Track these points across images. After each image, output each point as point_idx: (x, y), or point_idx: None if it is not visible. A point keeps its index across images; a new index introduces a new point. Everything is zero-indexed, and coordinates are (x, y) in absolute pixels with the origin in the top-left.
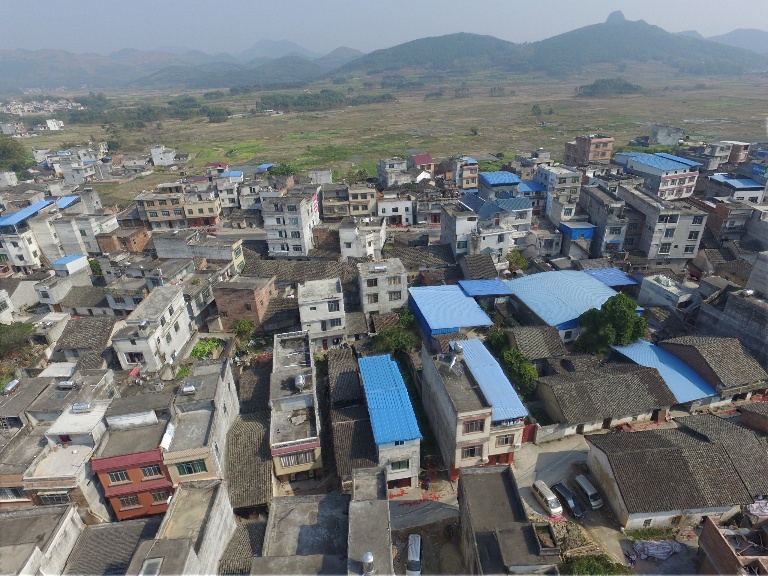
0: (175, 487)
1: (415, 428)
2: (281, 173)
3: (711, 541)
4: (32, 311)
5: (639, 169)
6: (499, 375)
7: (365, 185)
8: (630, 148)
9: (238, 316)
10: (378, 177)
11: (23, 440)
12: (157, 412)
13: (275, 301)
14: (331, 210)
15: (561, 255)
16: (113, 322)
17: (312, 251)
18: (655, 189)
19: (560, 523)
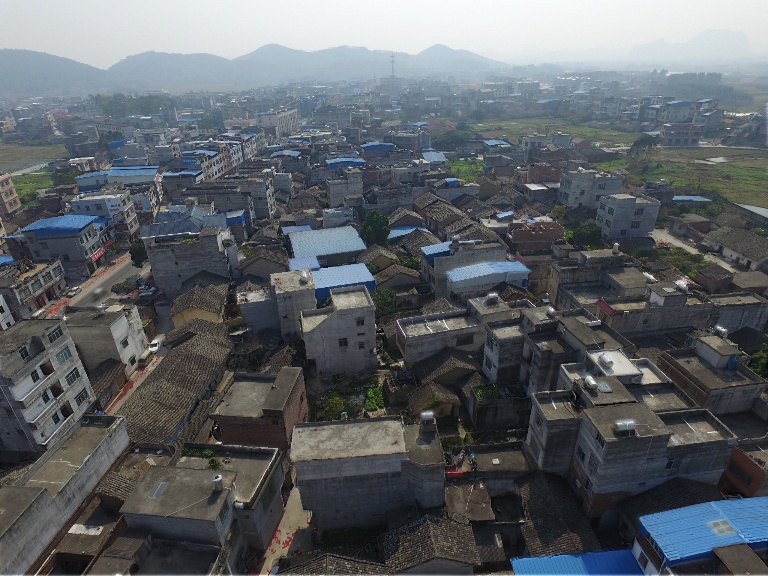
0: None
1: (515, 262)
2: None
3: (519, 236)
4: None
5: (126, 182)
6: None
7: None
8: None
9: None
10: None
11: None
12: None
13: None
14: None
15: (238, 243)
16: (337, 557)
17: None
18: None
19: None
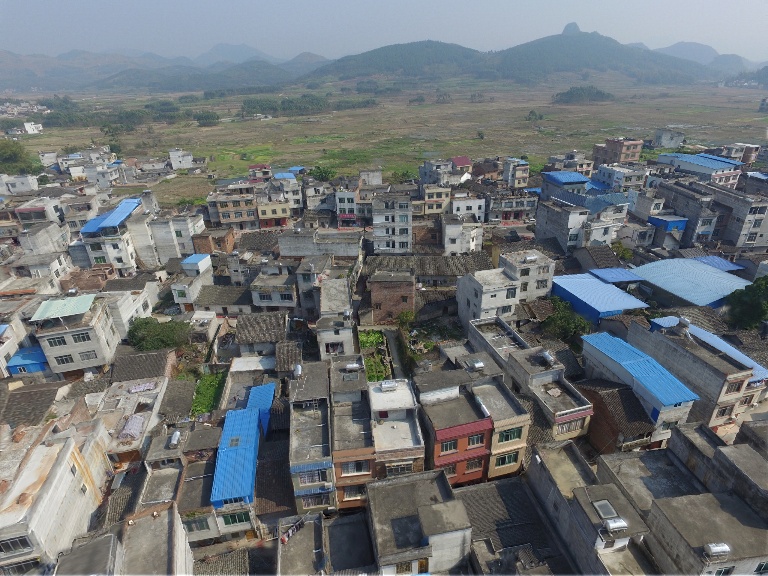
0: (494, 454)
1: (689, 391)
2: (319, 175)
3: None
4: (161, 312)
5: (687, 168)
6: (724, 345)
7: (436, 185)
8: None
9: (392, 308)
10: (420, 178)
11: (334, 420)
12: (461, 387)
13: (420, 293)
14: None
15: (654, 246)
16: (284, 316)
17: (415, 247)
18: None
19: None
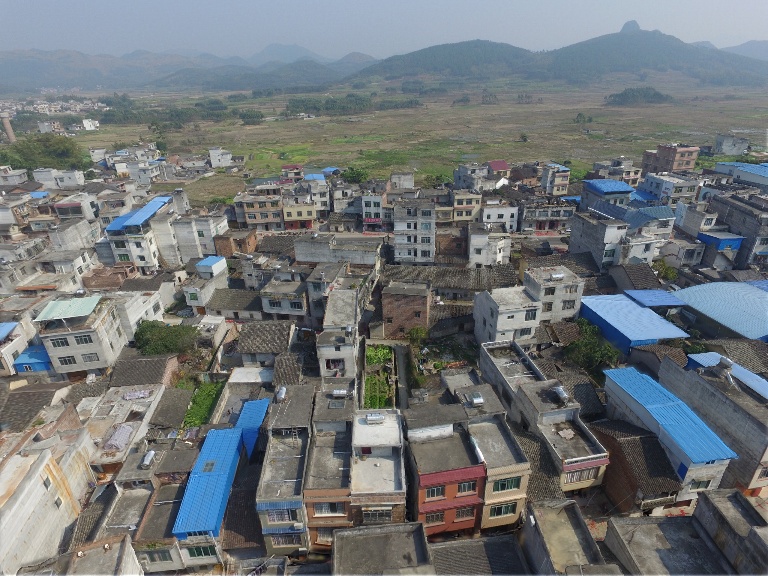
0: (487, 504)
1: (725, 447)
2: (352, 177)
3: None
4: (174, 313)
5: (748, 179)
6: None
7: (467, 191)
8: None
9: (404, 322)
10: (454, 182)
11: (314, 451)
12: (455, 425)
13: (435, 308)
14: None
15: (703, 265)
16: (289, 327)
17: (438, 257)
18: None
19: None
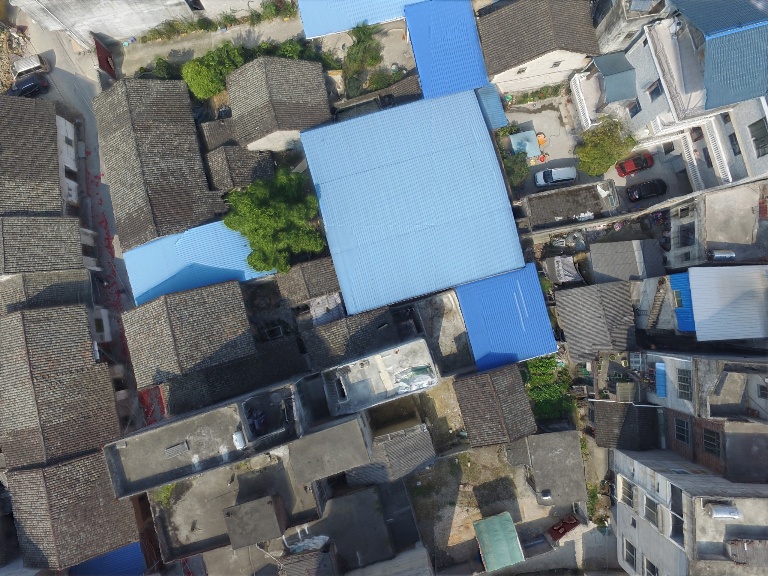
0: None
1: None
2: None
3: None
4: None
5: None
6: None
7: None
8: None
9: None
10: None
11: None
12: None
13: None
14: None
15: (658, 268)
16: None
17: None
18: None
19: (4, 75)
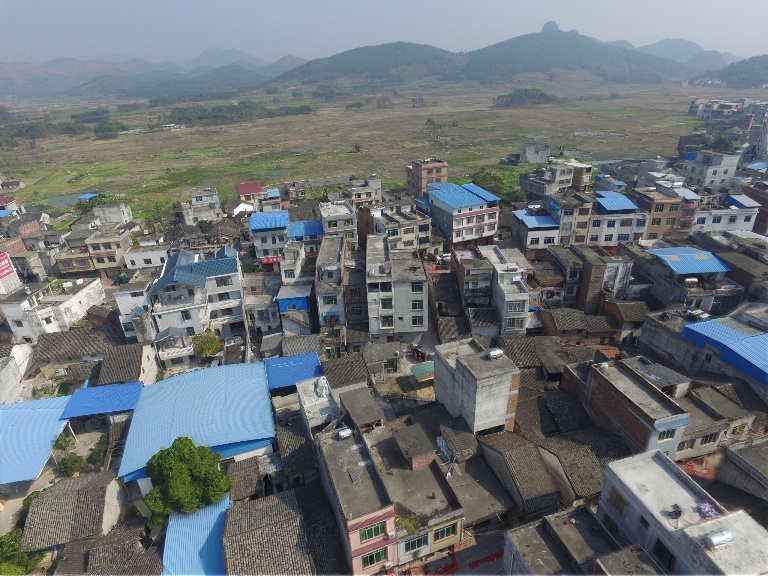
0: None
1: None
2: (92, 206)
3: None
4: None
5: (437, 205)
6: None
7: (118, 231)
8: (498, 167)
9: None
10: None
11: None
12: None
13: None
14: (69, 264)
15: (279, 329)
16: None
17: None
18: (450, 228)
19: None
